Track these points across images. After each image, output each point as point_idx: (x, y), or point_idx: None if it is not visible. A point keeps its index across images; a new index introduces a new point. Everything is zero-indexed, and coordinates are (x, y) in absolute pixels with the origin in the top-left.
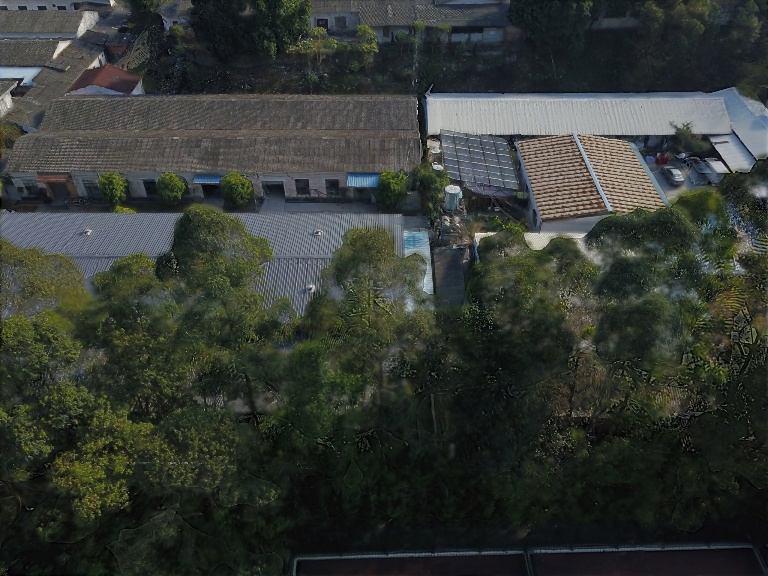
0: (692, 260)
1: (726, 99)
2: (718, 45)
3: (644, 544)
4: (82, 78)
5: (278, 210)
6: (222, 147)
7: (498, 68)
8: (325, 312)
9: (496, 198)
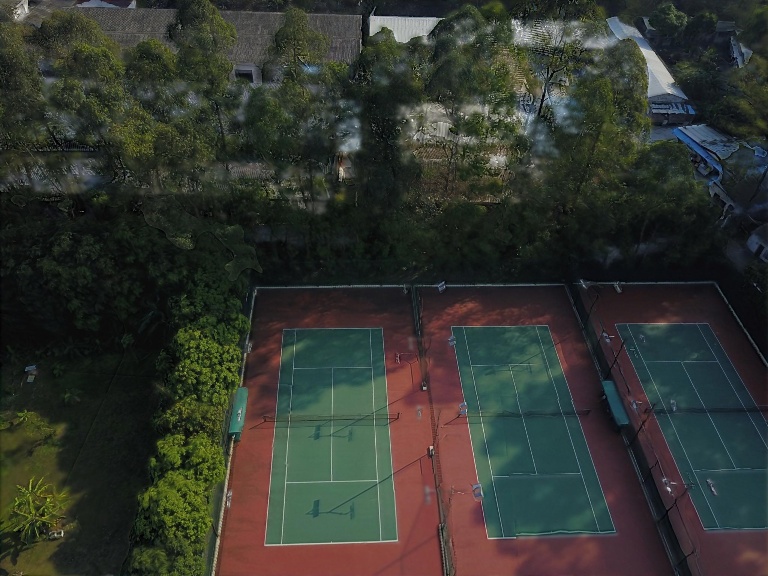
0: (483, 38)
1: None
2: None
3: (492, 283)
4: None
5: None
6: None
7: None
8: (270, 69)
9: None
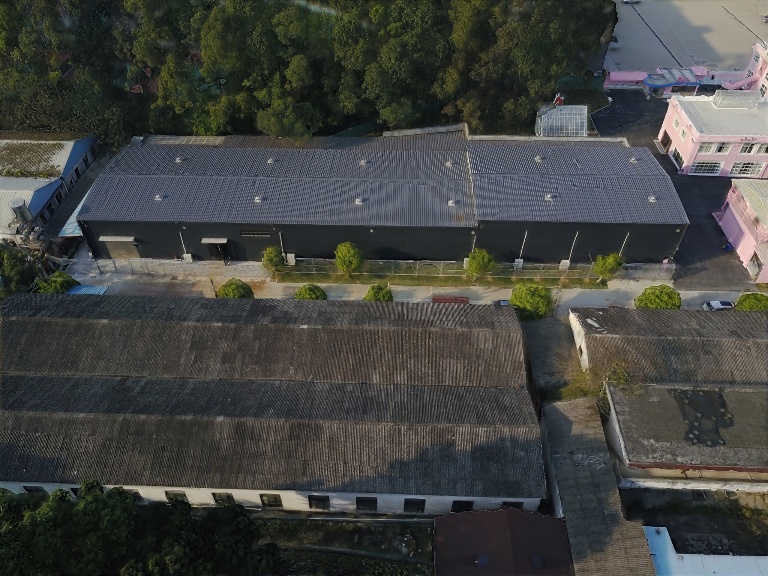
0: None
1: None
2: None
3: None
4: (561, 573)
5: None
6: (244, 316)
7: None
8: None
9: None
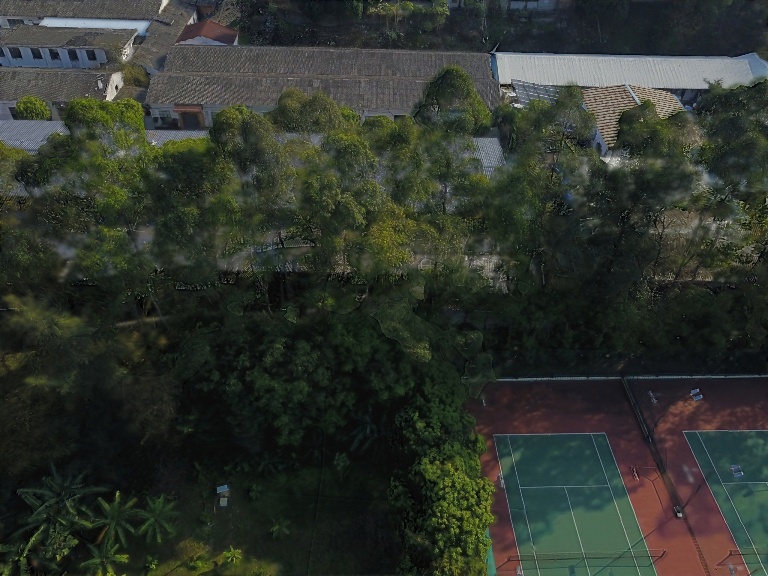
0: None
1: (749, 62)
2: (740, 18)
3: (711, 374)
4: (187, 31)
5: None
6: (331, 87)
7: (551, 33)
8: (525, 152)
9: None
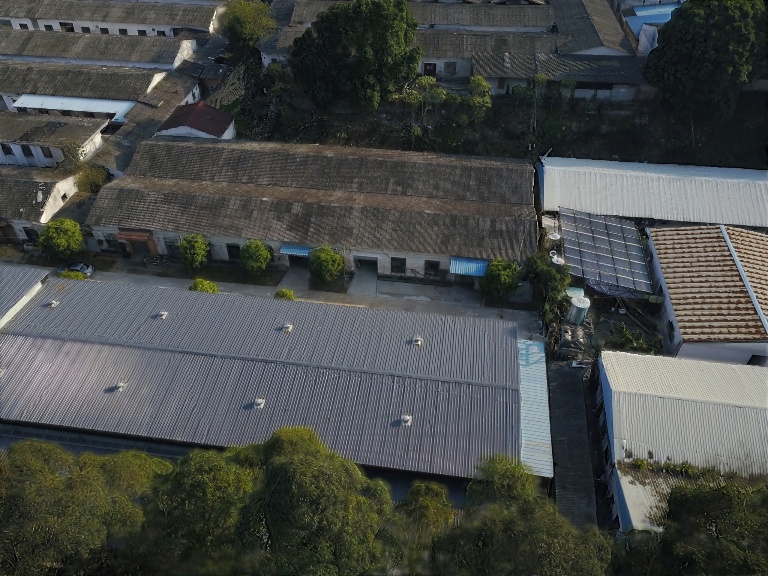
0: None
1: None
2: None
3: None
4: (174, 116)
5: (369, 289)
6: (314, 214)
7: (626, 131)
8: None
9: (623, 299)
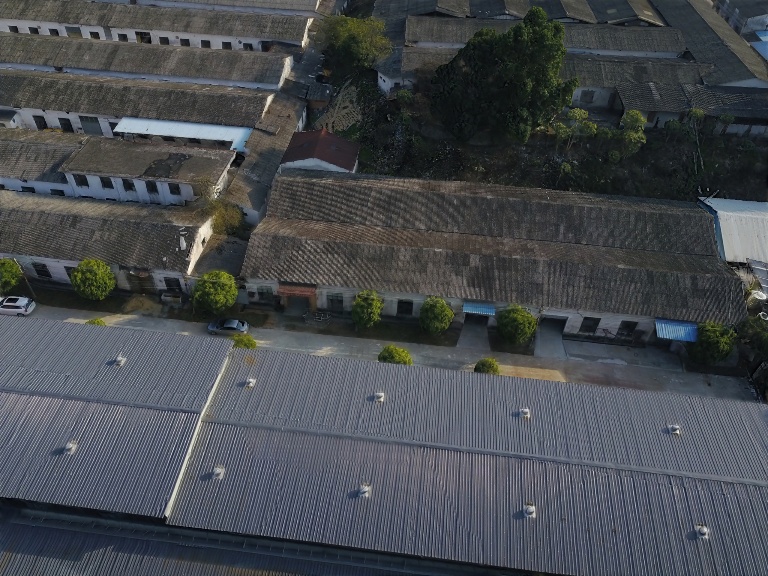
0: None
1: None
2: None
3: None
4: (295, 145)
5: (557, 350)
6: (496, 267)
7: None
8: None
9: None
